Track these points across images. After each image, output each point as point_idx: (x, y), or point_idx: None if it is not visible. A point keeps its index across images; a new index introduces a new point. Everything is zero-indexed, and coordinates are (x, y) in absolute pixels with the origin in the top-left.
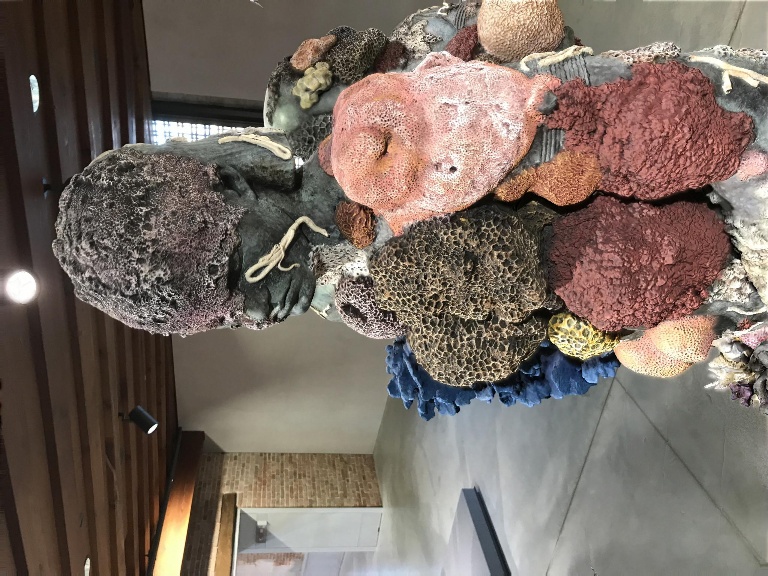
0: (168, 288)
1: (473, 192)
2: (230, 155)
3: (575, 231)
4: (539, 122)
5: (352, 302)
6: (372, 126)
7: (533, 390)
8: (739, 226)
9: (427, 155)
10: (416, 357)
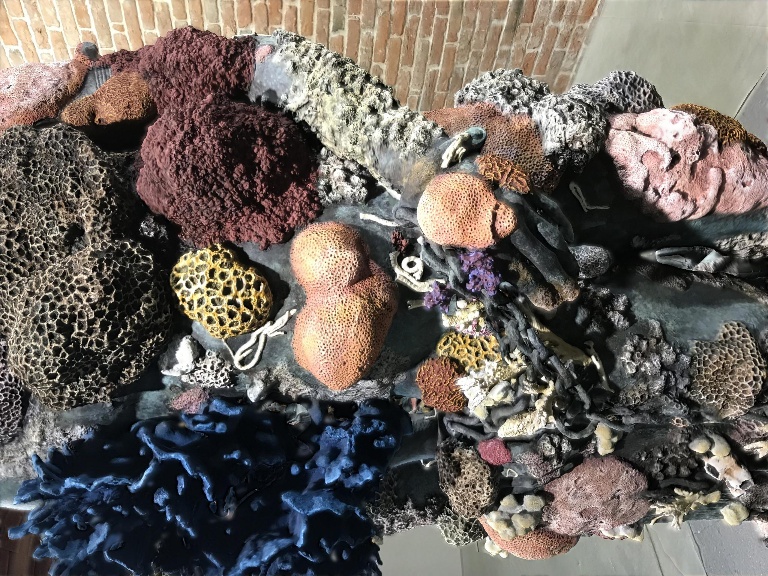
0: None
1: (28, 100)
2: None
3: None
4: (90, 67)
5: None
6: None
7: (271, 545)
8: (283, 96)
9: None
10: None
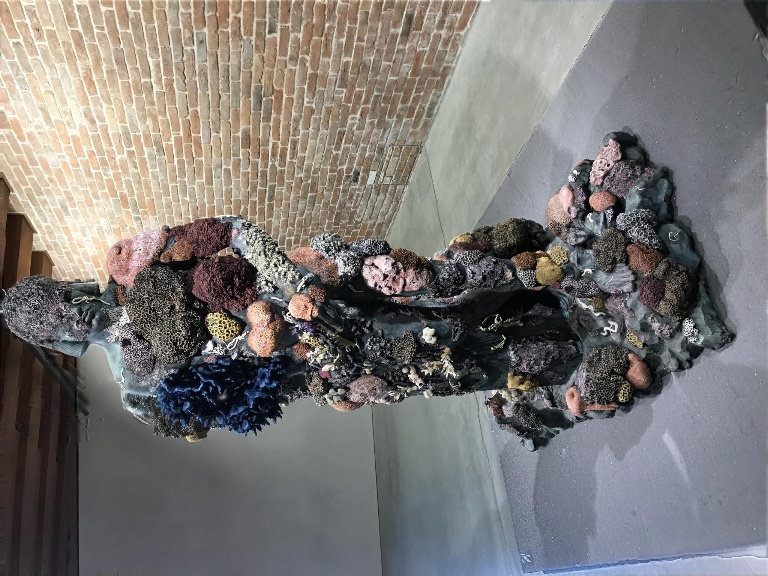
0: (41, 291)
1: (149, 256)
2: (73, 285)
3: (193, 270)
4: (167, 236)
5: (124, 335)
6: (115, 247)
7: None
8: (243, 253)
9: (132, 248)
10: (154, 353)
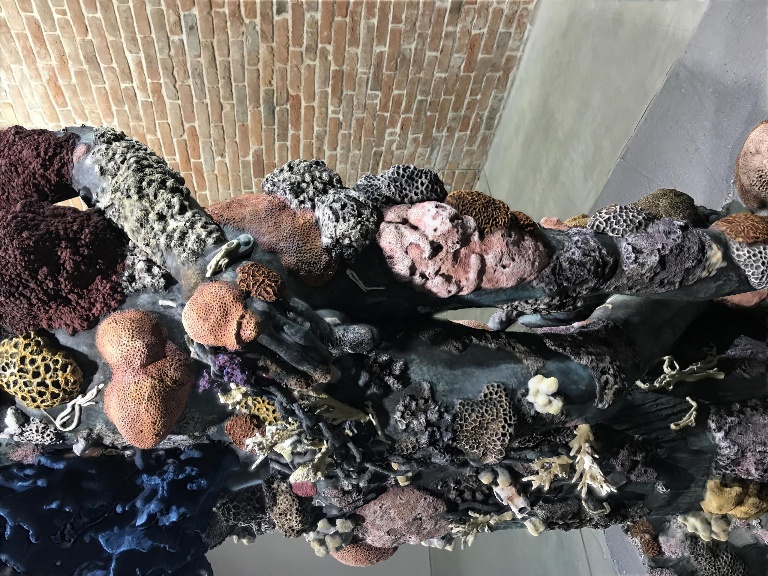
0: None
1: None
2: None
3: None
4: None
5: None
6: None
7: None
8: (94, 195)
9: None
10: None
